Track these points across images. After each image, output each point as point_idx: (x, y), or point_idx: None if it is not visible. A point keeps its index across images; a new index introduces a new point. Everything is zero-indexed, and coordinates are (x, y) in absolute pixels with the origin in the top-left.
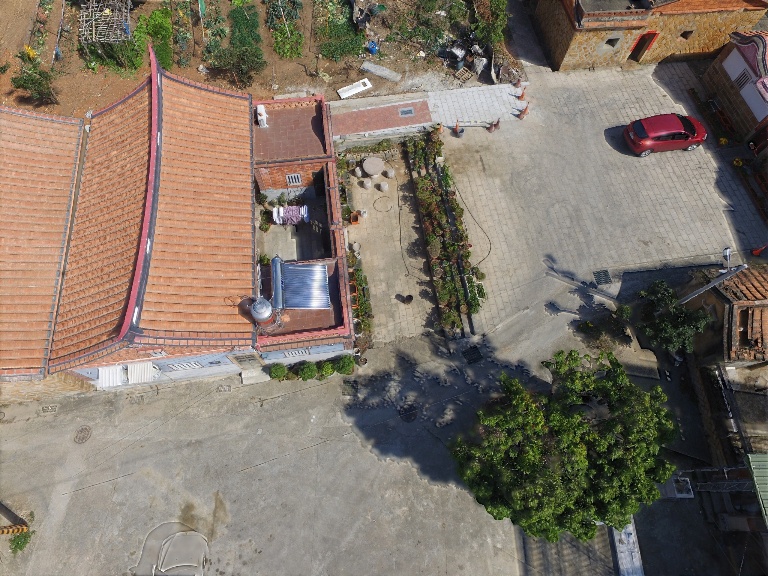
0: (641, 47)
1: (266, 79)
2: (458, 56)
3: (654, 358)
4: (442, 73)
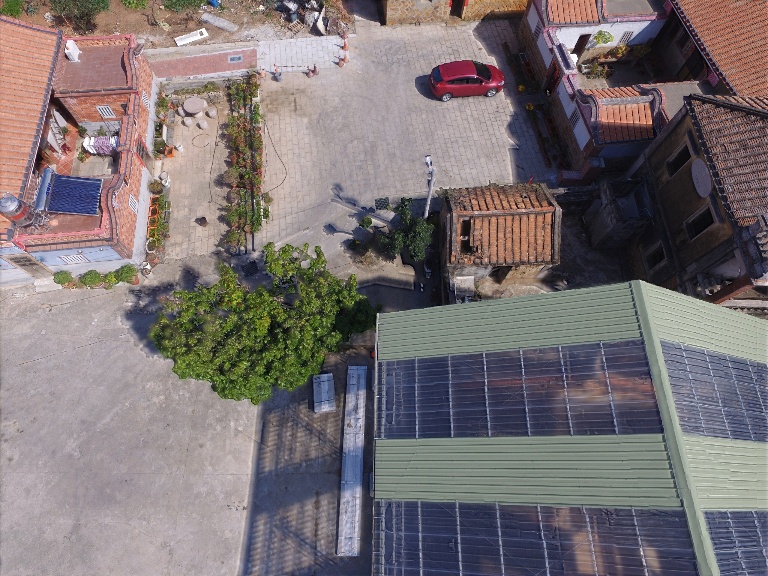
0: (461, 4)
1: (109, 27)
2: (291, 9)
3: (412, 272)
4: (278, 25)
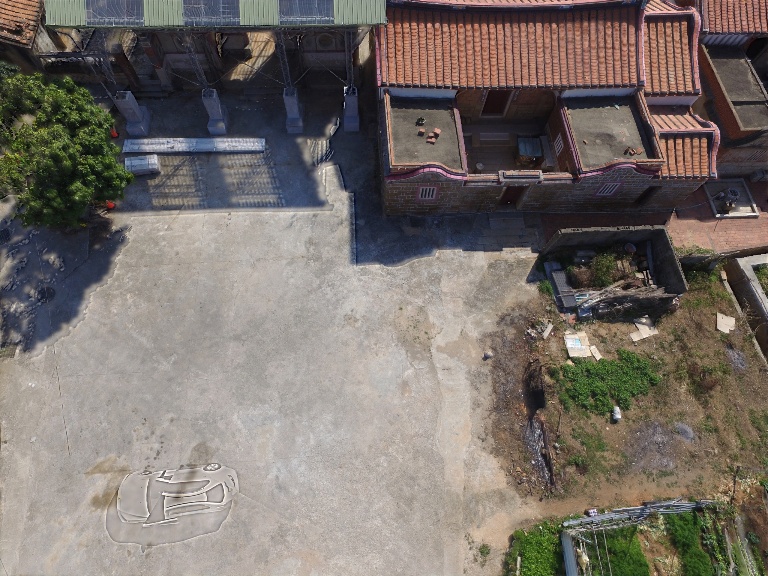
0: None
1: None
2: None
3: None
4: None
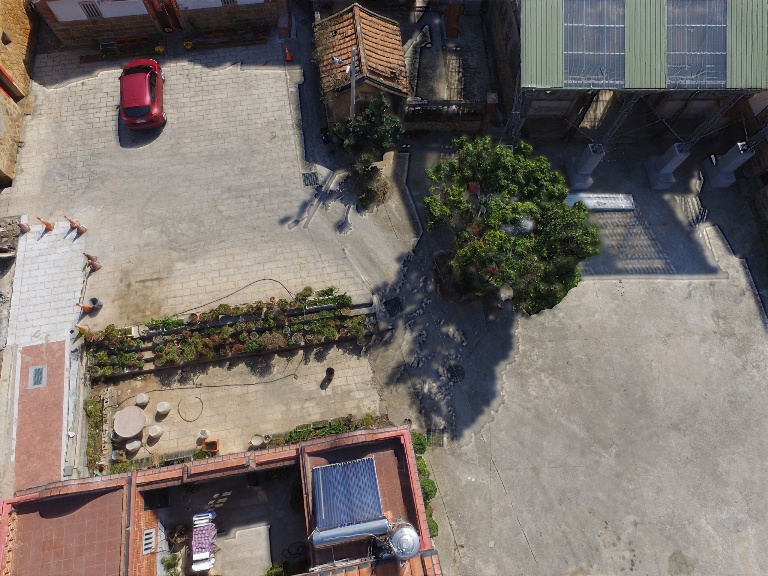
0: (5, 87)
1: None
2: None
3: (391, 153)
4: None
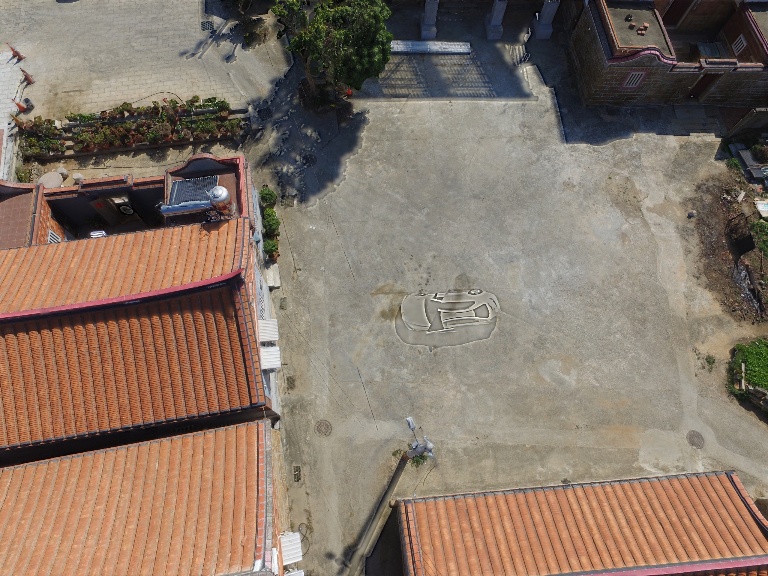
0: None
1: None
2: None
3: None
4: None
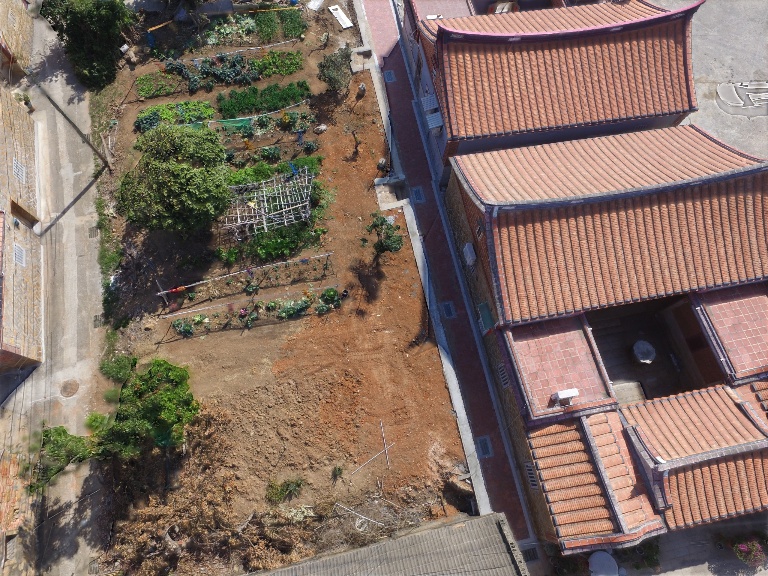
0: None
1: None
2: None
3: None
4: None
